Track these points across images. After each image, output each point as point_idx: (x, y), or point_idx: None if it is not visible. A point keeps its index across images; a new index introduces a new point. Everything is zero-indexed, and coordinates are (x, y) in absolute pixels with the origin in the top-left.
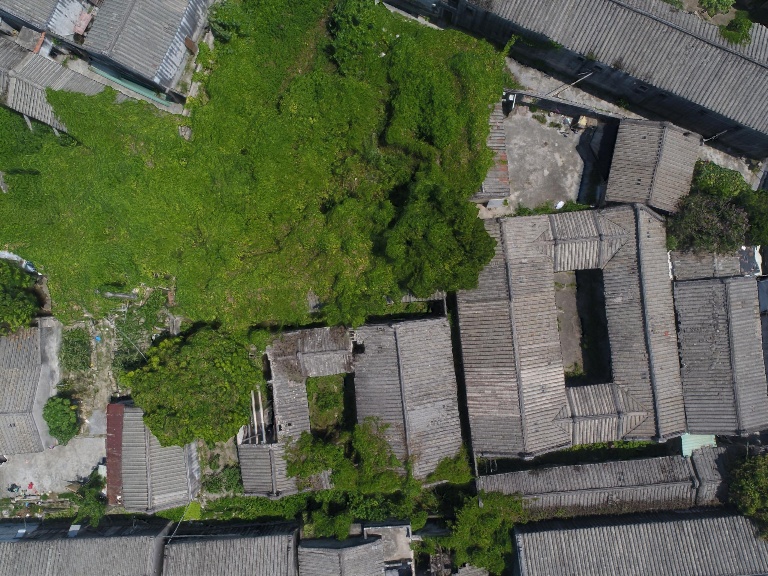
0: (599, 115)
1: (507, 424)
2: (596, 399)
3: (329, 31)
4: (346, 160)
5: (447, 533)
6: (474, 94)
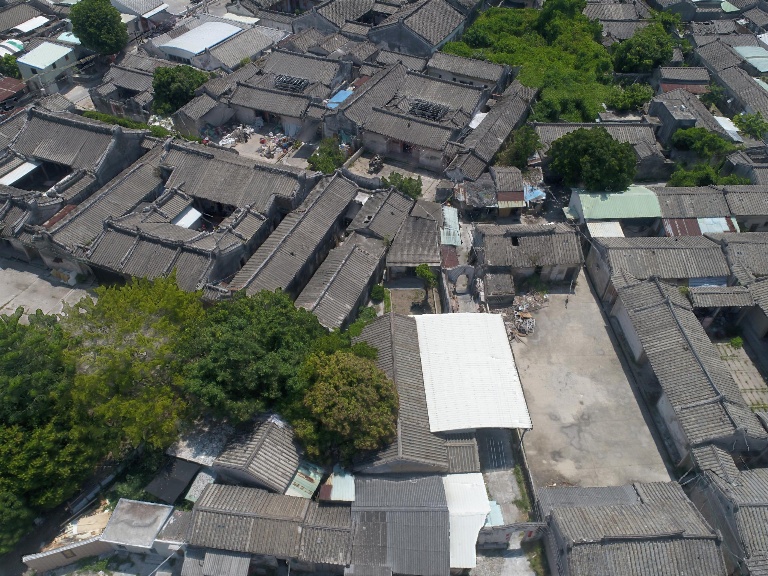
0: (501, 6)
1: (624, 8)
2: (606, 2)
3: (474, 49)
4: (531, 42)
5: (672, 26)
6: (505, 8)
